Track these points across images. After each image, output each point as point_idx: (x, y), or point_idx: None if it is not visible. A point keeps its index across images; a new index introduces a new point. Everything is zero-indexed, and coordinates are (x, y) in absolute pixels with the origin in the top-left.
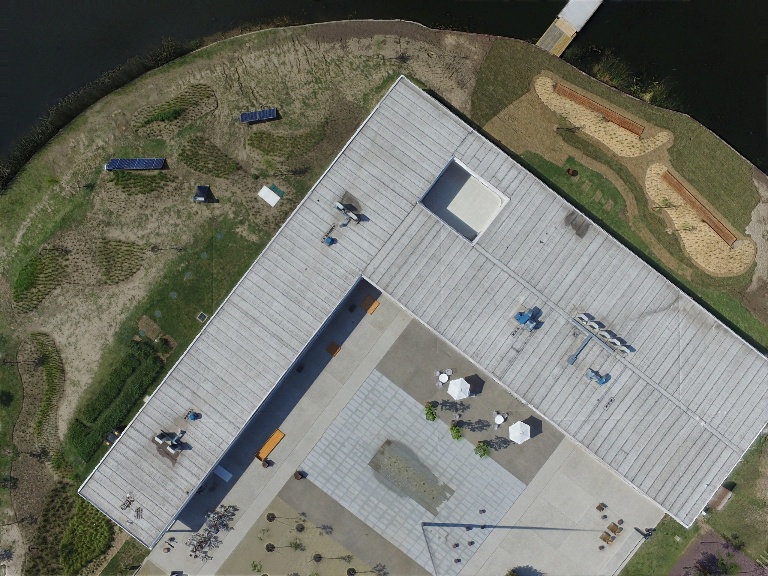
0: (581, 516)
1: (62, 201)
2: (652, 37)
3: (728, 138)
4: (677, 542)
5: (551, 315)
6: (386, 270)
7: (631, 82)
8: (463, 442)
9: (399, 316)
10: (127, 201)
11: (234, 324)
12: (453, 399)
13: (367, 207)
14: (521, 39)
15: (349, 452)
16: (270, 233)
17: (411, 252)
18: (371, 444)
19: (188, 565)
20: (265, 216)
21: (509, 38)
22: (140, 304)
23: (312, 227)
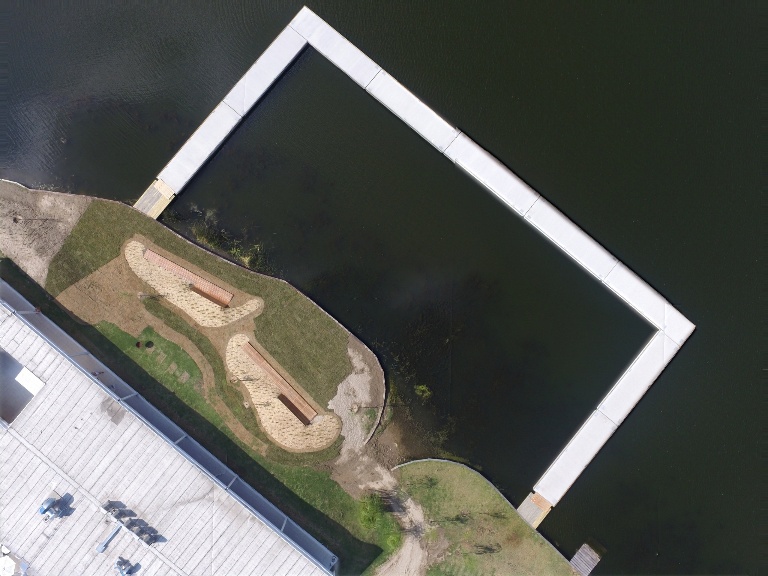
0: None
1: None
2: (258, 198)
3: (330, 303)
4: None
5: (83, 502)
6: None
7: (225, 247)
8: None
9: None
10: None
11: None
12: (17, 569)
13: None
14: (119, 200)
15: None
16: None
17: None
18: None
19: None
20: None
21: (106, 200)
22: None
23: None
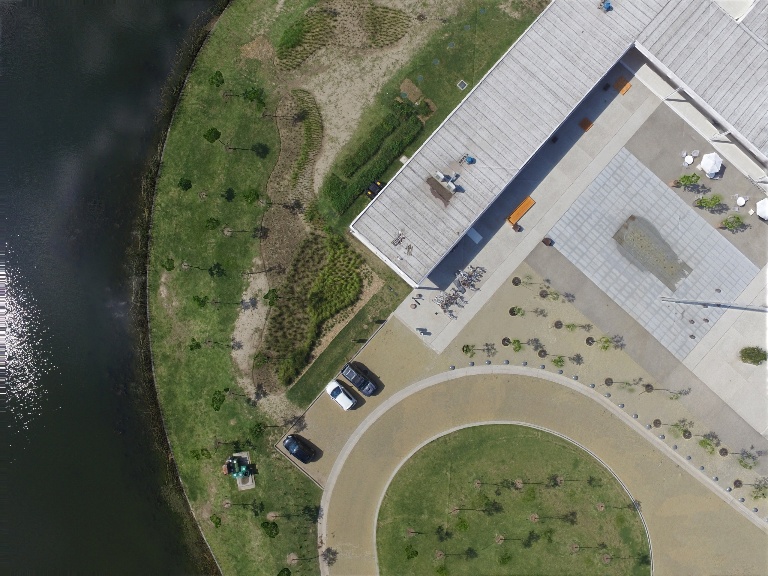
0: None
1: None
2: None
3: None
4: None
5: None
6: (658, 39)
7: None
8: (703, 223)
9: (649, 99)
10: None
11: (512, 77)
12: None
13: None
14: None
15: (595, 224)
16: (532, 11)
17: (681, 24)
18: (616, 218)
19: (433, 323)
20: None
21: None
22: (403, 68)
23: None
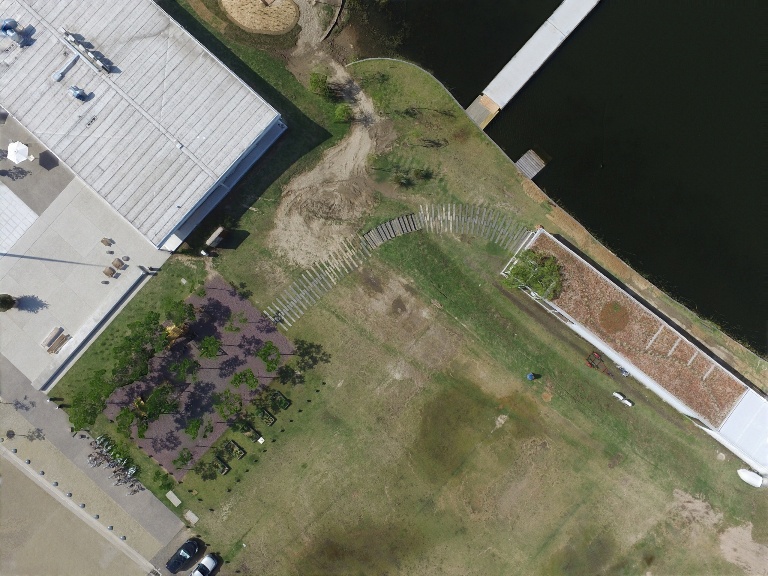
0: (89, 250)
1: None
2: None
3: None
4: (183, 285)
5: (44, 33)
6: None
7: None
8: None
9: None
10: None
11: None
12: None
13: None
14: None
15: None
16: None
17: None
18: None
19: None
20: None
21: None
22: None
23: None
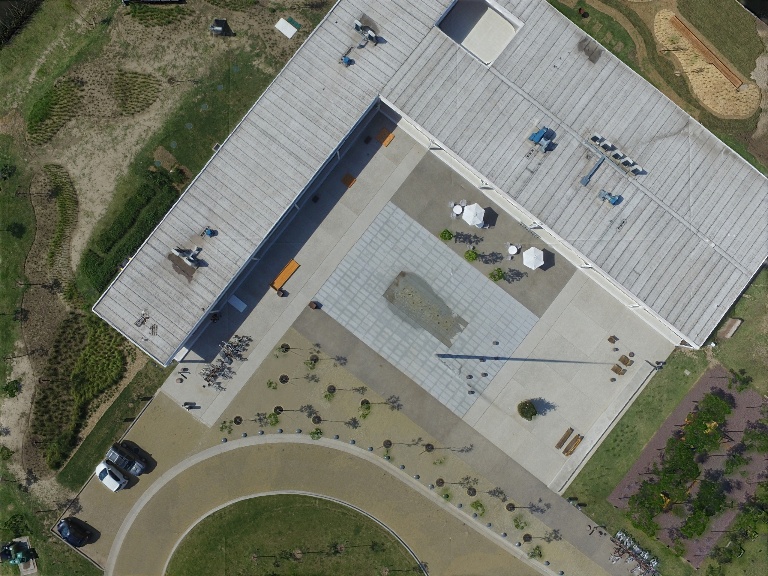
0: (593, 349)
1: (78, 37)
2: None
3: None
4: (687, 376)
5: (565, 137)
6: (403, 91)
7: None
8: (477, 274)
9: (414, 149)
10: (144, 33)
11: (252, 142)
12: (467, 231)
13: (384, 29)
14: None
15: (364, 283)
16: None
17: (428, 73)
18: (386, 275)
19: (201, 396)
20: (282, 48)
21: None
22: (156, 135)
23: (330, 48)
